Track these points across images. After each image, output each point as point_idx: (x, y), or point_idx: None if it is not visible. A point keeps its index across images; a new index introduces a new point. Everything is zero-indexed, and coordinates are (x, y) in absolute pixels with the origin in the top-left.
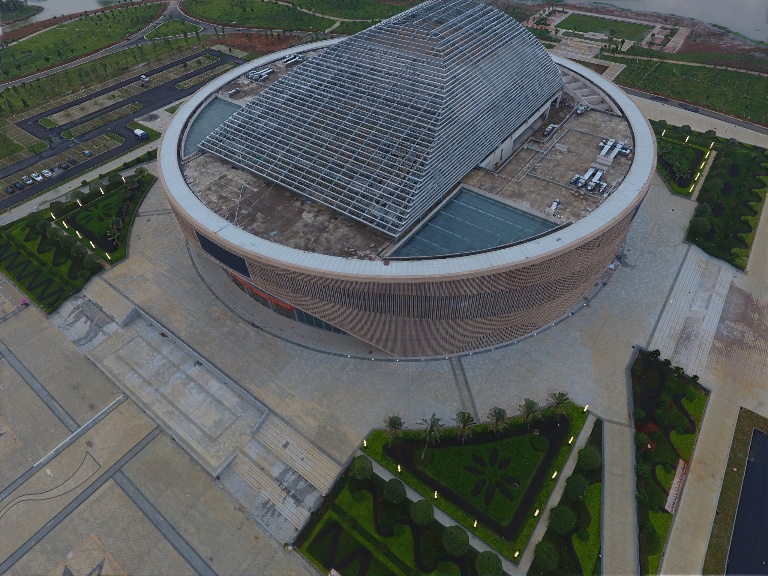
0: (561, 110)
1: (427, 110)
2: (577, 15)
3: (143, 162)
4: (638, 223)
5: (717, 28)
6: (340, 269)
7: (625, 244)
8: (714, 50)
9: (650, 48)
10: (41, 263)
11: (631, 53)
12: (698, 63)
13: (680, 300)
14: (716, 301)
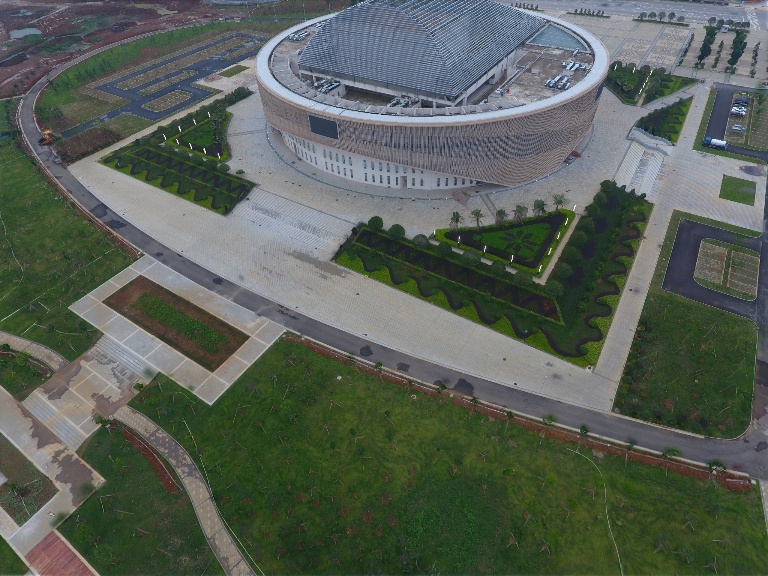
0: None
1: None
2: None
3: (660, 115)
4: None
5: None
6: None
7: None
8: None
9: None
10: (624, 68)
11: (8, 358)
12: None
13: None
14: None
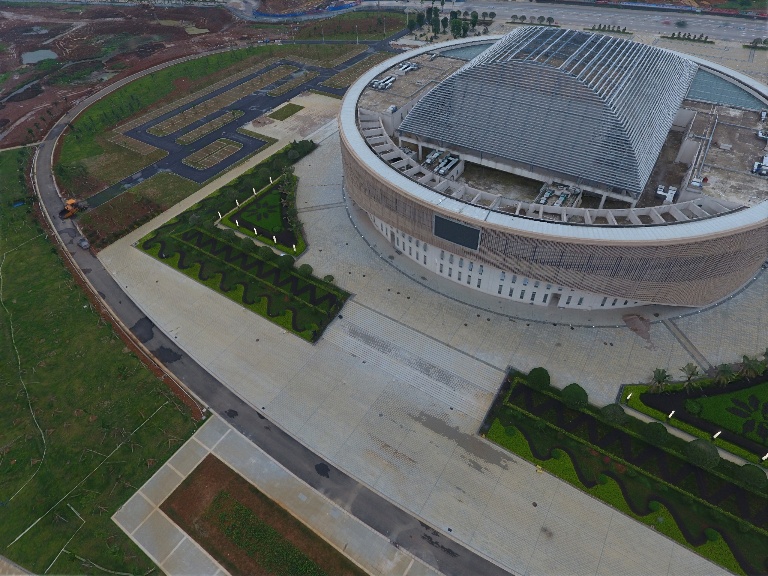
0: None
1: None
2: None
3: None
4: None
5: None
6: None
7: None
8: None
9: None
10: None
11: None
12: None
13: None
14: None
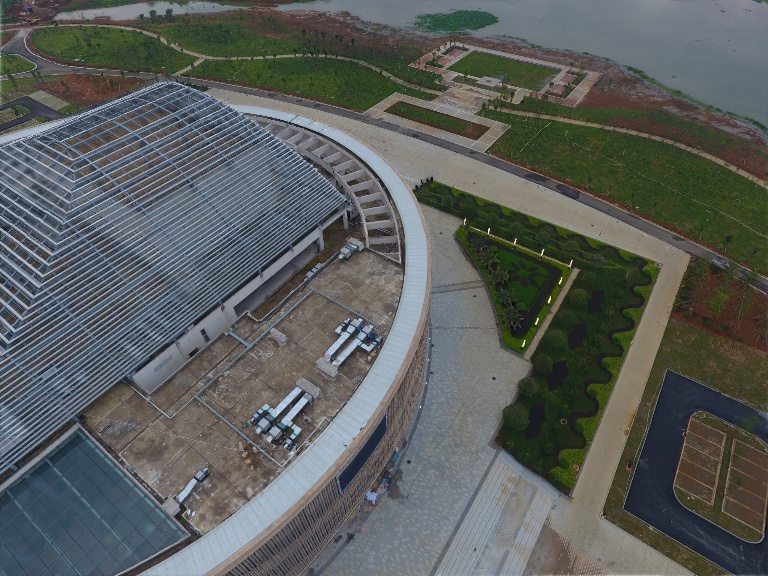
0: (351, 232)
1: (7, 311)
2: (478, 53)
3: None
4: (439, 405)
5: (632, 72)
6: None
7: (407, 449)
8: (620, 104)
9: (546, 101)
10: None
11: (522, 108)
12: (596, 123)
13: (455, 570)
14: (512, 565)
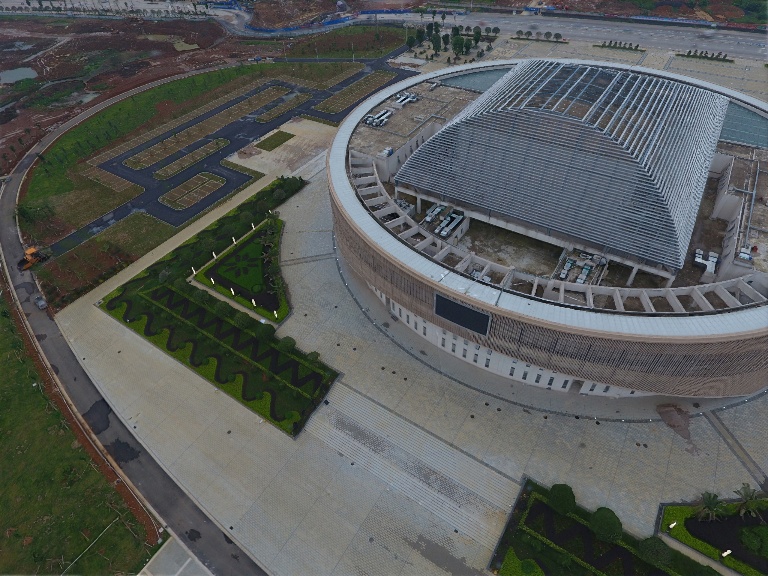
0: None
1: None
2: None
3: None
4: None
5: None
6: (547, 59)
7: None
8: None
9: None
10: None
11: None
12: None
13: None
14: None
